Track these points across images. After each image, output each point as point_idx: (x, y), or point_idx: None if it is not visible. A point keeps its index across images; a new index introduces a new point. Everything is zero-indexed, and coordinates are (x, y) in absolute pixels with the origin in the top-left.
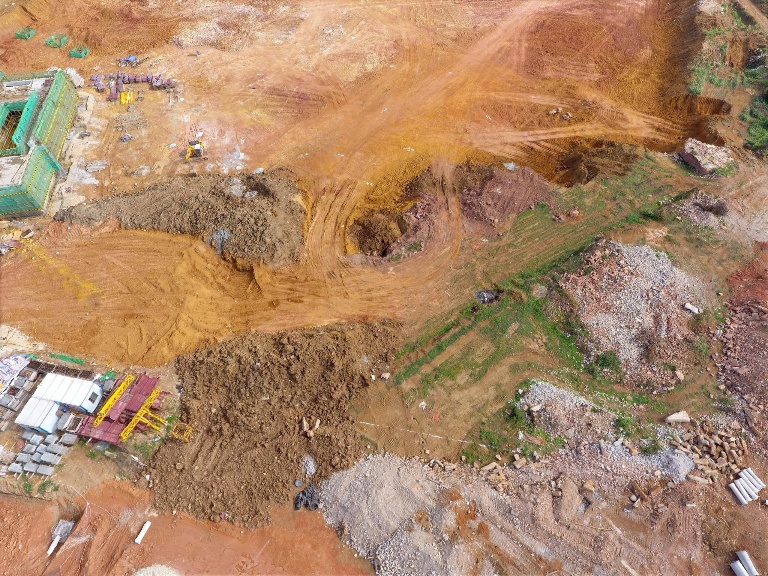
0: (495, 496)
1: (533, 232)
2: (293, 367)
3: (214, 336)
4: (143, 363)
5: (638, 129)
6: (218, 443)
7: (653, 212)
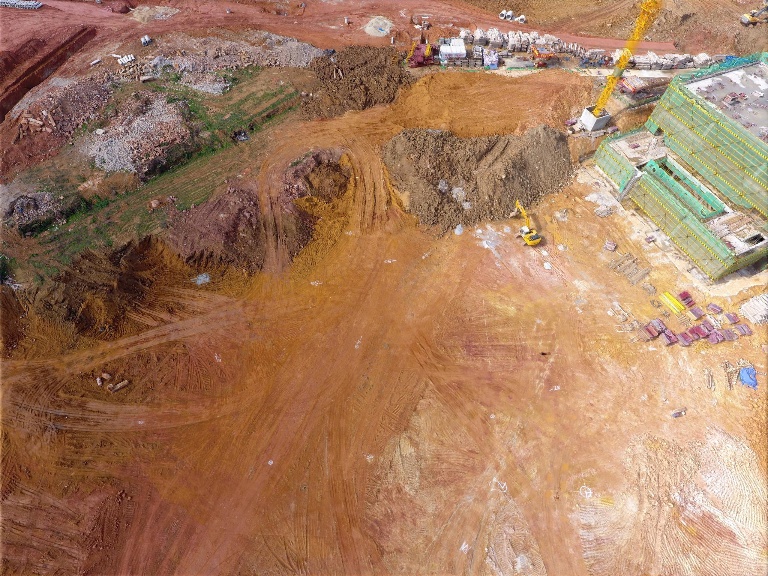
0: (247, 49)
1: (198, 185)
2: None
3: None
4: None
5: (8, 374)
6: None
7: (81, 204)
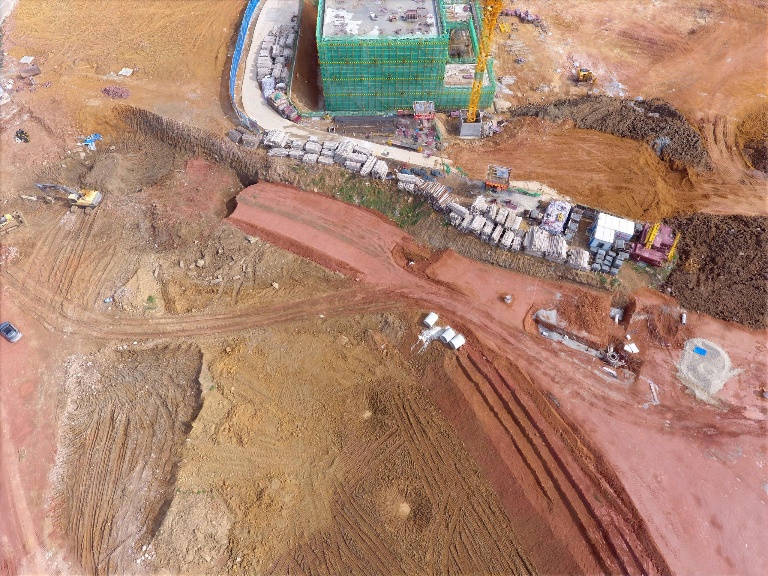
0: None
1: None
2: (763, 235)
3: (682, 210)
4: (644, 219)
5: None
6: (710, 277)
7: None
